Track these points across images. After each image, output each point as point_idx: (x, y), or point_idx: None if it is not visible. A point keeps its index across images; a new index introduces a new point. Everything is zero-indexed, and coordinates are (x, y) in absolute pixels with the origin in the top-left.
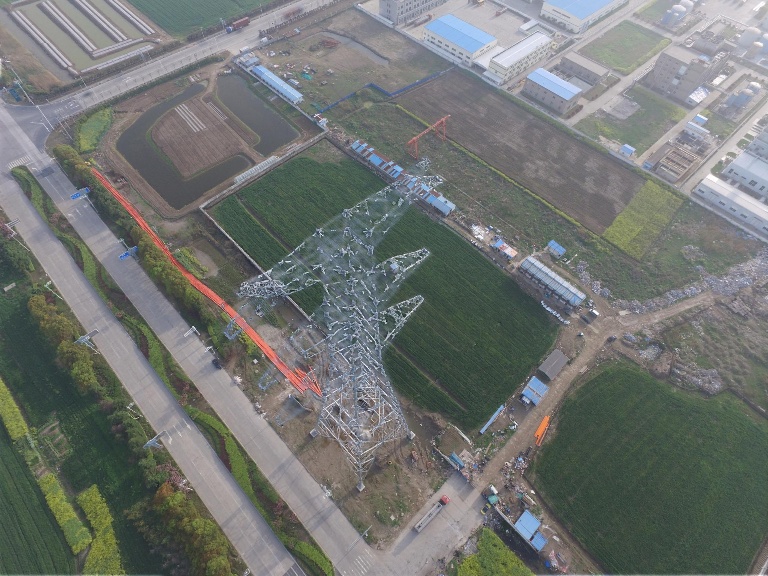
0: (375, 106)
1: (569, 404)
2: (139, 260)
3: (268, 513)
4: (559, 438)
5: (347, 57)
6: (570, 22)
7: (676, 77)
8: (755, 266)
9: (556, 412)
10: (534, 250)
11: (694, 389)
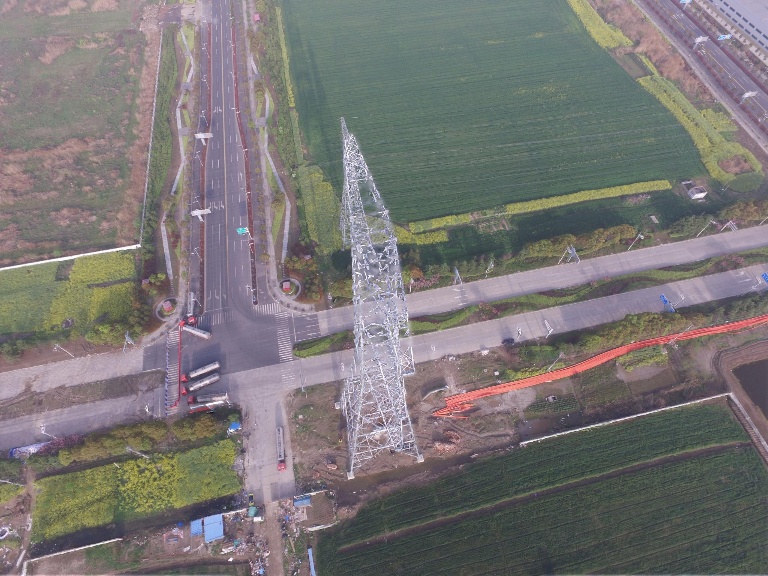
0: None
1: None
2: None
3: None
4: None
5: None
6: None
7: None
8: None
9: None
10: None
11: None
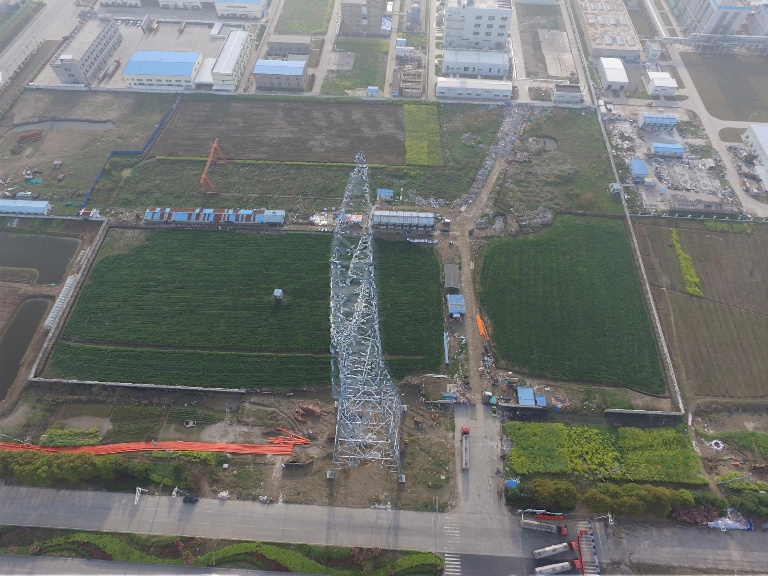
0: (135, 170)
1: (483, 296)
2: (4, 481)
3: (351, 569)
4: (496, 323)
5: (63, 140)
6: (249, 11)
7: (363, 18)
8: (509, 124)
9: (480, 308)
10: (371, 205)
11: (540, 227)
